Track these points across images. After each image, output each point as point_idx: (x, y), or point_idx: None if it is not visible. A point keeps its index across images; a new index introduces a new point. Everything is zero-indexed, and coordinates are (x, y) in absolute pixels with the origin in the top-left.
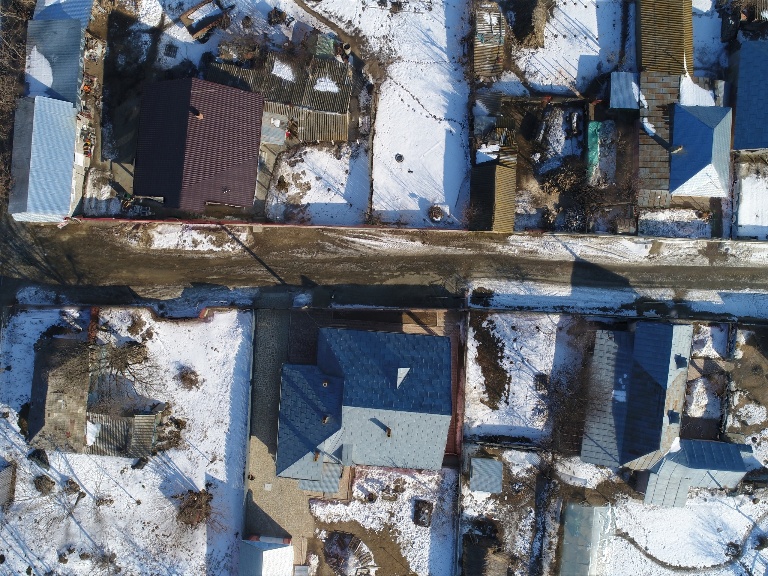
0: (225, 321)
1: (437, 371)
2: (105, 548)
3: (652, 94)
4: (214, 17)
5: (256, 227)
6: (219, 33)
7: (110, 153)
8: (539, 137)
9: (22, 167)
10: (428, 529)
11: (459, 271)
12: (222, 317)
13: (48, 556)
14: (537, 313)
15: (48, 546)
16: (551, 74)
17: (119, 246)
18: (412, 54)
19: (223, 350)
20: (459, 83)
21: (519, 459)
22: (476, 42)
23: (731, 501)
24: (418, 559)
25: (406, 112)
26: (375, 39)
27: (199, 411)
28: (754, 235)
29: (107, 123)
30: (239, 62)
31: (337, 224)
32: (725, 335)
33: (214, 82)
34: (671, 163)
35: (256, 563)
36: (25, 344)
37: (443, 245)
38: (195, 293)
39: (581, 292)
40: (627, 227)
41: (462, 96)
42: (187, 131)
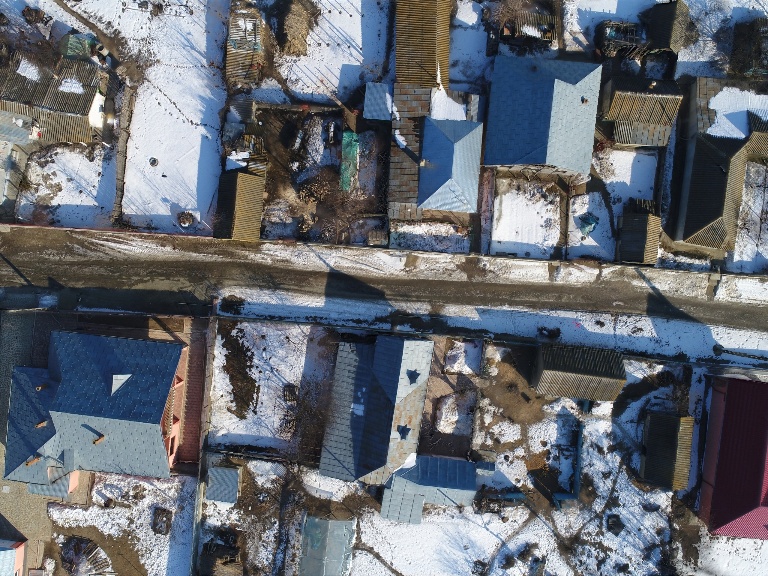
0: None
1: (158, 379)
2: None
3: (404, 106)
4: None
5: (3, 227)
6: None
7: None
8: (294, 146)
9: None
10: (167, 537)
11: (210, 278)
12: None
13: None
14: (287, 323)
15: None
16: (312, 82)
17: None
18: (171, 57)
19: None
20: (217, 88)
21: (264, 469)
22: (229, 48)
23: (479, 519)
24: (156, 567)
25: (162, 116)
26: (134, 41)
27: None
28: (513, 252)
29: None
30: None
31: (87, 226)
32: (479, 351)
33: None
34: (420, 176)
35: None
36: None
37: (194, 251)
38: None
39: (335, 303)
40: (378, 239)
41: (219, 102)
42: None
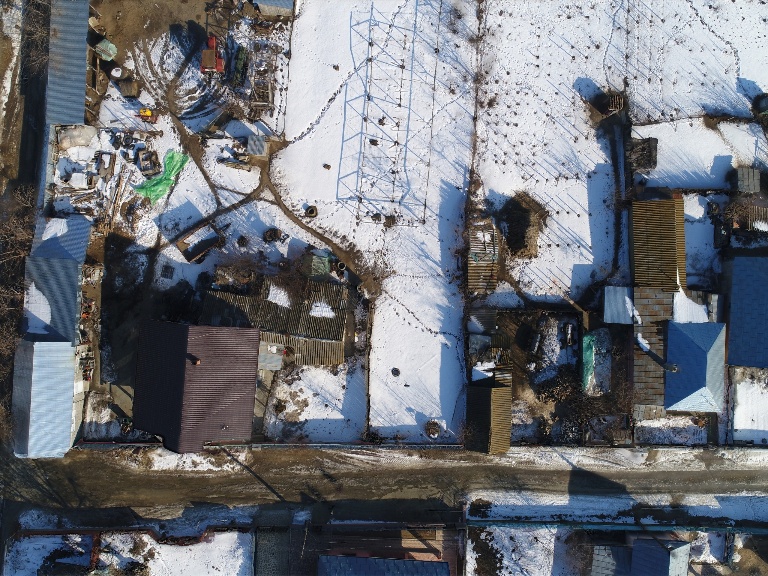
0: (226, 541)
1: None
2: None
3: (646, 310)
4: (210, 240)
5: (255, 446)
6: (215, 253)
7: (109, 376)
8: (534, 350)
9: (22, 410)
10: None
11: (457, 483)
12: (223, 537)
13: None
14: (535, 524)
15: None
16: (545, 284)
17: (120, 468)
18: (407, 268)
19: (224, 569)
20: (454, 296)
21: None
22: (470, 261)
23: None
24: None
25: (402, 326)
26: (370, 253)
27: None
28: (750, 439)
29: (106, 346)
30: (235, 286)
31: (335, 440)
32: (722, 541)
33: None
34: (666, 379)
35: None
36: (28, 569)
37: (440, 458)
38: (195, 512)
39: (578, 500)
40: (623, 439)
41: (457, 309)
42: (185, 378)
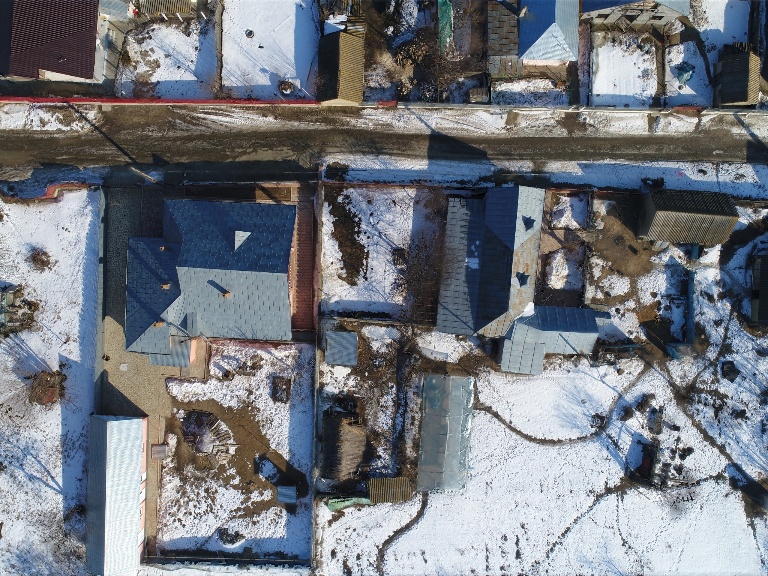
0: (75, 200)
1: (278, 235)
2: None
3: None
4: None
5: (105, 105)
6: None
7: None
8: (389, 8)
9: None
10: (287, 406)
11: (313, 146)
12: (72, 196)
13: None
14: (393, 186)
15: None
16: None
17: None
18: None
19: (74, 230)
20: None
21: (378, 334)
22: None
23: (595, 372)
24: (278, 436)
25: None
26: None
27: (52, 292)
28: (612, 104)
29: None
30: None
31: (187, 101)
32: (584, 205)
33: None
34: (519, 28)
35: (102, 434)
36: None
37: (296, 120)
38: (45, 174)
39: (438, 165)
40: (480, 96)
41: None
42: None
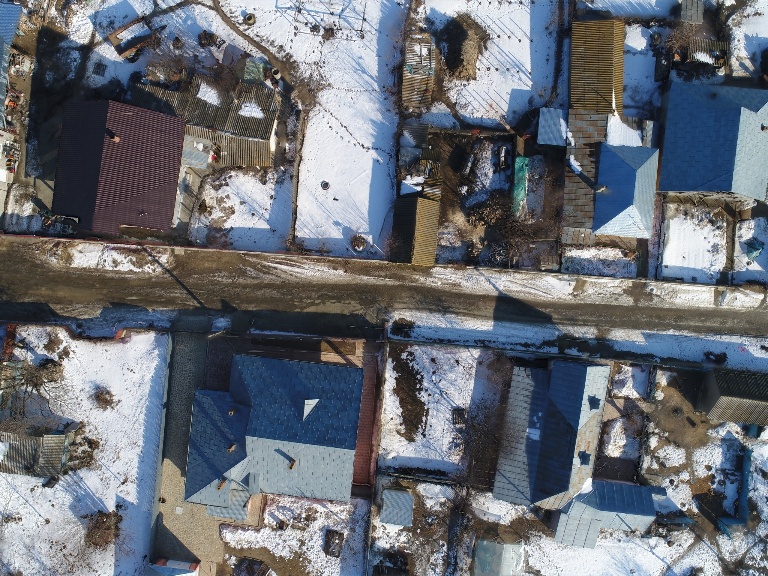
0: (142, 343)
1: (346, 403)
2: (11, 566)
3: (579, 132)
4: (143, 37)
5: (178, 249)
6: (149, 53)
7: (34, 169)
8: (466, 170)
9: None
10: (338, 559)
11: (381, 301)
12: (139, 338)
13: None
14: (457, 346)
15: None
16: (482, 107)
17: (39, 263)
18: (342, 81)
19: (139, 371)
20: (388, 112)
21: (433, 492)
22: (405, 73)
23: (645, 543)
24: None
25: (334, 139)
26: (306, 65)
27: (113, 432)
28: (680, 276)
29: (32, 139)
30: (166, 84)
31: (259, 249)
32: (646, 376)
33: (137, 104)
34: (595, 202)
35: None
36: None
37: (365, 274)
38: (114, 313)
39: (503, 327)
40: (550, 264)
41: (391, 126)
42: (102, 154)
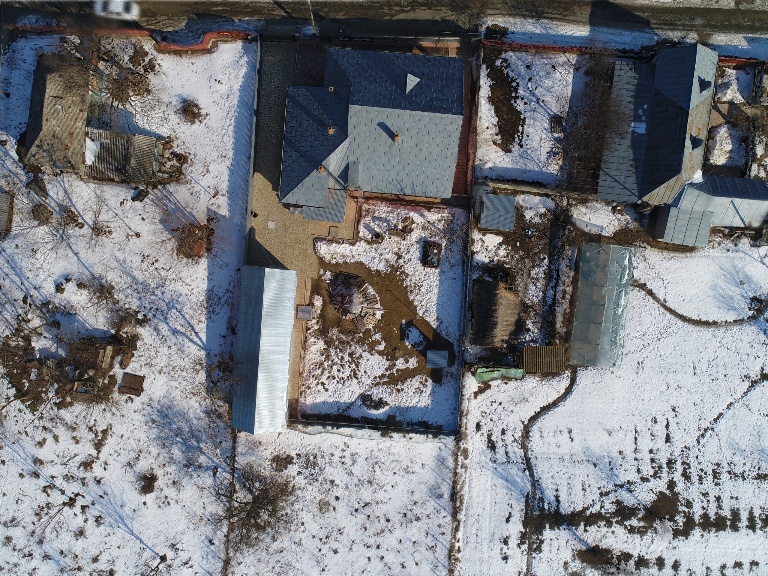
0: (229, 51)
1: (448, 82)
2: (103, 279)
3: None
4: None
5: None
6: None
7: None
8: None
9: None
10: (437, 272)
11: (472, 7)
12: (226, 47)
13: (45, 286)
14: (553, 51)
15: (45, 276)
16: None
17: None
18: None
19: (227, 82)
20: None
21: (532, 203)
22: None
23: (755, 252)
24: (426, 303)
25: None
26: None
27: (201, 145)
28: None
29: None
30: None
31: None
32: (751, 78)
33: None
34: None
35: (258, 282)
36: (25, 70)
37: None
38: (199, 24)
39: (600, 32)
40: None
41: None
42: None
